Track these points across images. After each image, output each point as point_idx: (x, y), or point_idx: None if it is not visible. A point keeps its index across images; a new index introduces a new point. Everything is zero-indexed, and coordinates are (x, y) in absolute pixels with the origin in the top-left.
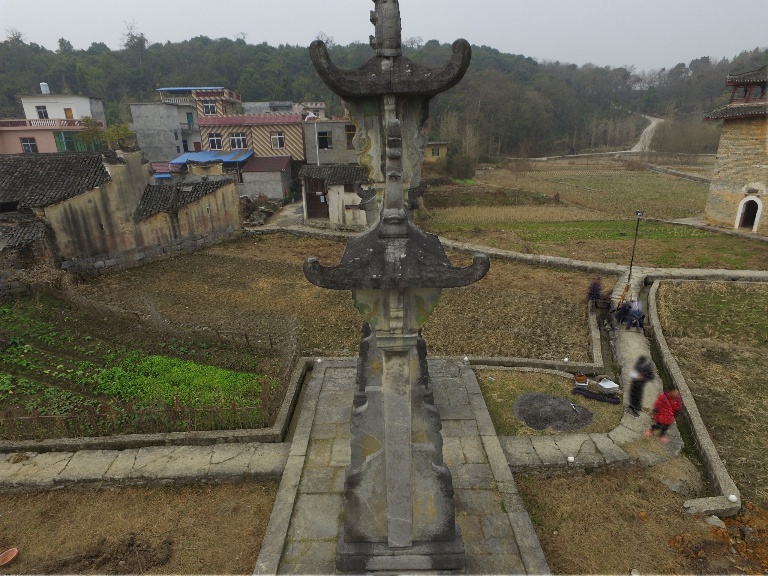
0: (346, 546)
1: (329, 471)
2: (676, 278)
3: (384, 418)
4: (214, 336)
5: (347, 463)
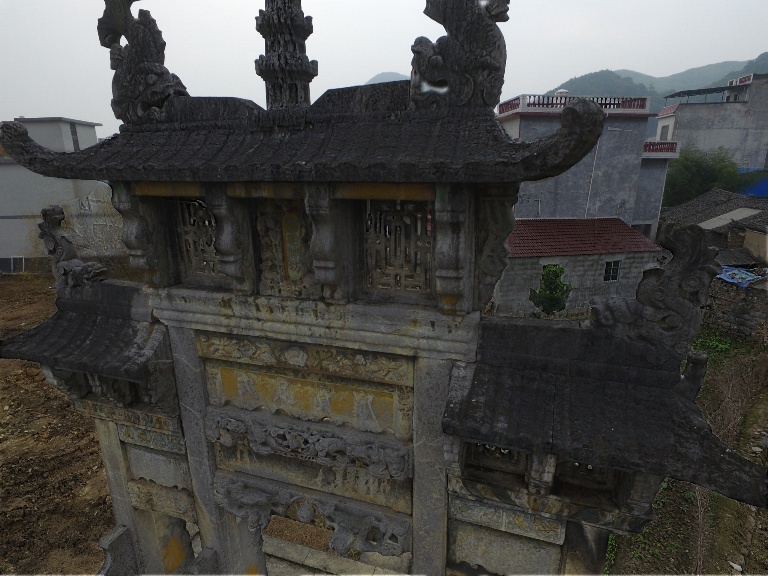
0: None
1: None
2: None
3: None
4: None
5: None
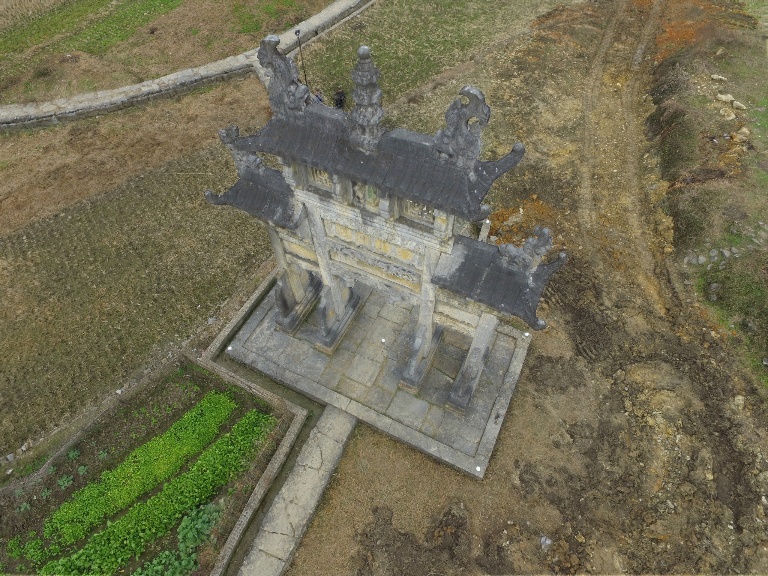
0: (465, 398)
1: (375, 389)
2: (286, 50)
3: (475, 339)
4: (80, 437)
5: (374, 376)
